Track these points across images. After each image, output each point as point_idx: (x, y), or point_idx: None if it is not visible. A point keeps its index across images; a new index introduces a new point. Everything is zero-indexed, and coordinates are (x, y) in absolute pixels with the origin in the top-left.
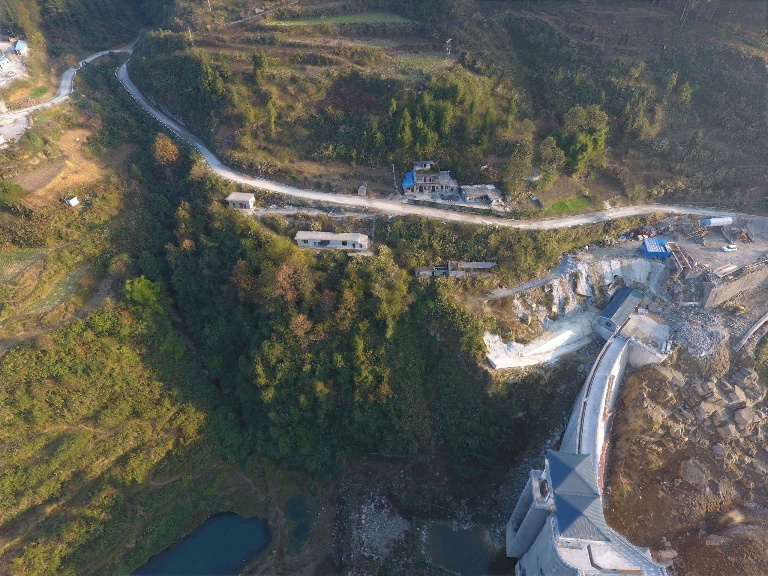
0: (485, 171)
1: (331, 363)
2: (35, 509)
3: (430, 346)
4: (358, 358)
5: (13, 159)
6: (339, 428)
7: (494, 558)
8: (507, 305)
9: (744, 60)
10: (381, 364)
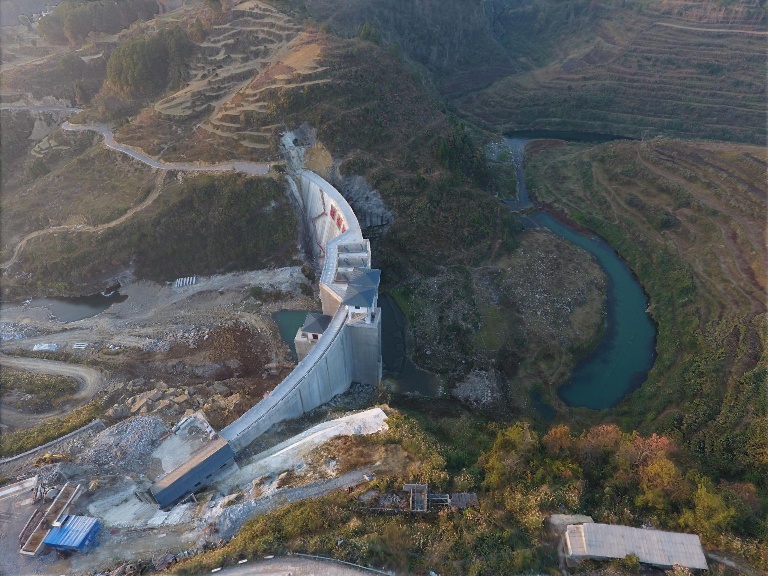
0: None
1: None
2: None
3: None
4: None
5: None
6: None
7: None
8: None
9: None
10: None
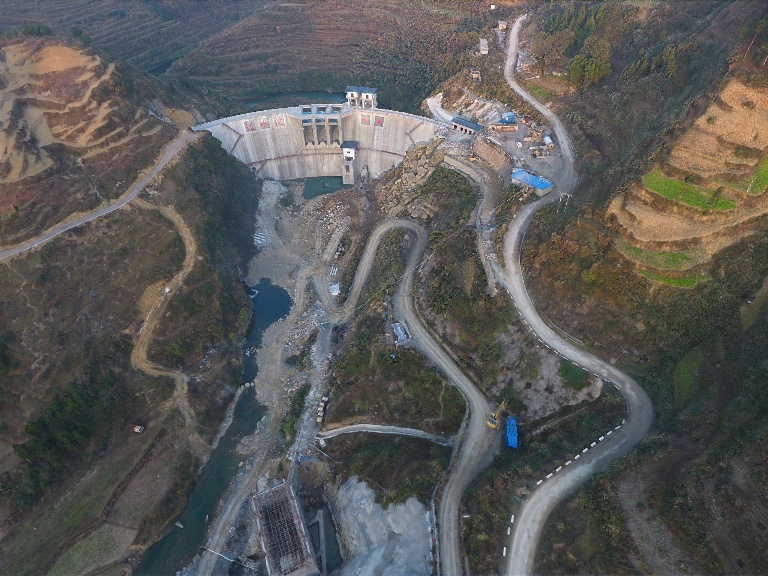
0: None
1: None
2: None
3: None
4: None
5: None
6: None
7: None
8: (460, 95)
9: (727, 63)
10: (432, 88)
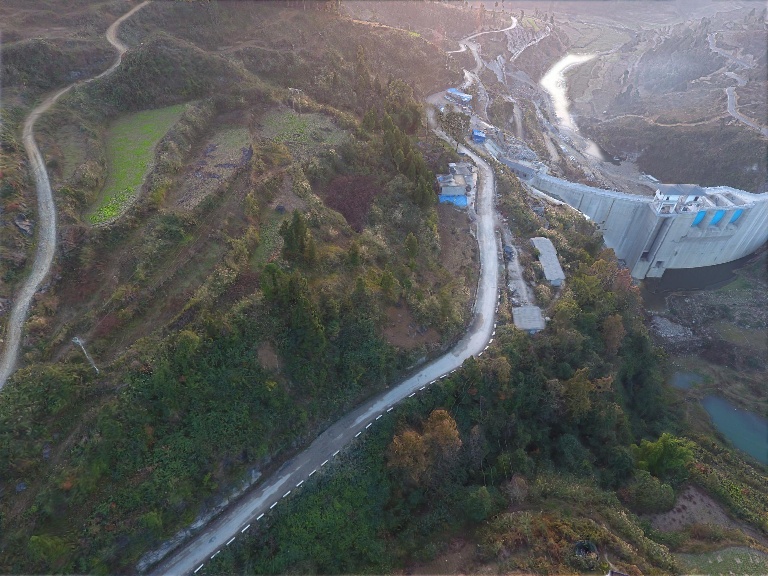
0: None
1: None
2: None
3: None
4: None
5: None
6: None
7: (648, 283)
8: None
9: (347, 25)
10: None
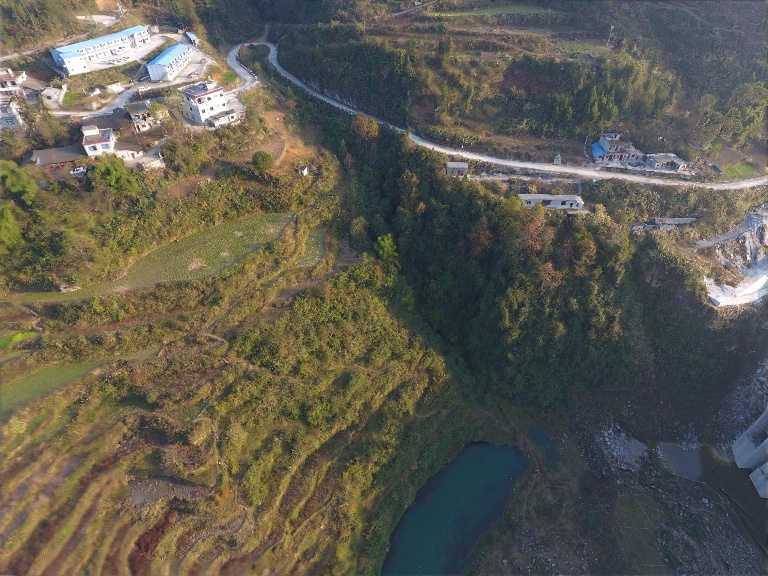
0: (661, 142)
1: (565, 307)
2: (340, 434)
3: (645, 292)
4: (592, 301)
5: (245, 134)
6: (569, 366)
7: (729, 469)
8: (712, 254)
9: None
10: (611, 306)
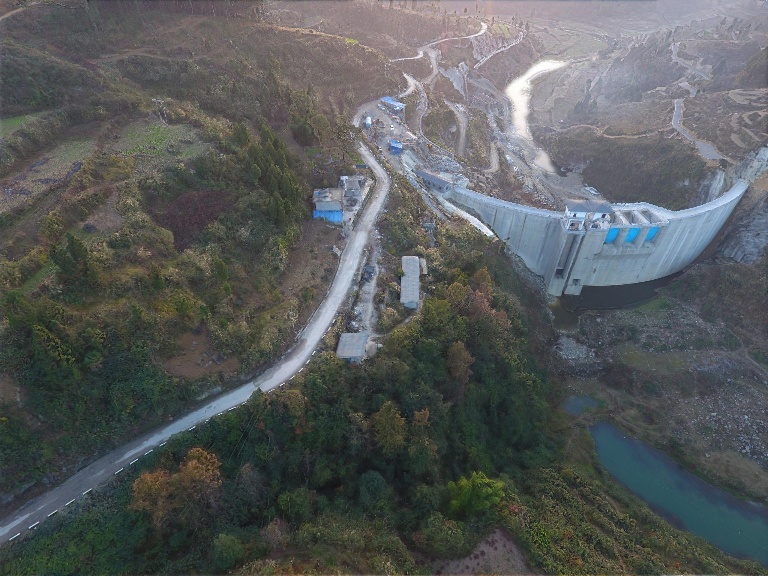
0: None
1: None
2: None
3: None
4: None
5: None
6: None
7: (564, 301)
8: None
9: (267, 32)
10: None
